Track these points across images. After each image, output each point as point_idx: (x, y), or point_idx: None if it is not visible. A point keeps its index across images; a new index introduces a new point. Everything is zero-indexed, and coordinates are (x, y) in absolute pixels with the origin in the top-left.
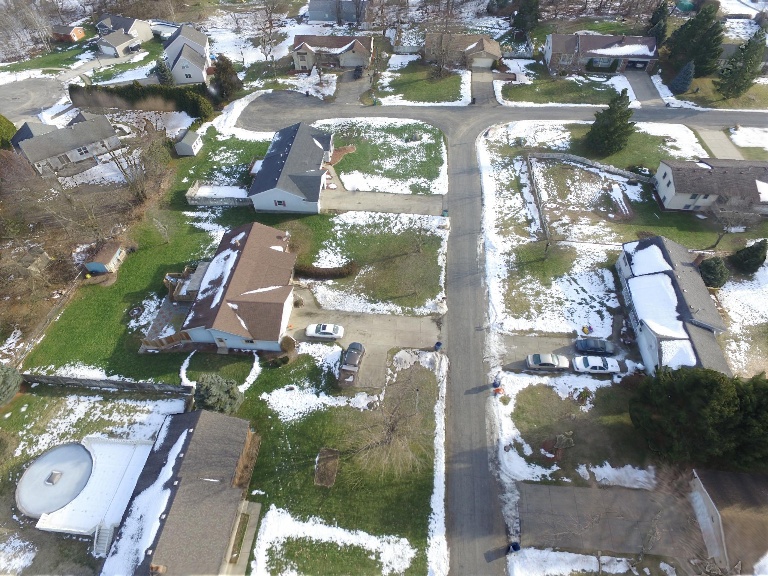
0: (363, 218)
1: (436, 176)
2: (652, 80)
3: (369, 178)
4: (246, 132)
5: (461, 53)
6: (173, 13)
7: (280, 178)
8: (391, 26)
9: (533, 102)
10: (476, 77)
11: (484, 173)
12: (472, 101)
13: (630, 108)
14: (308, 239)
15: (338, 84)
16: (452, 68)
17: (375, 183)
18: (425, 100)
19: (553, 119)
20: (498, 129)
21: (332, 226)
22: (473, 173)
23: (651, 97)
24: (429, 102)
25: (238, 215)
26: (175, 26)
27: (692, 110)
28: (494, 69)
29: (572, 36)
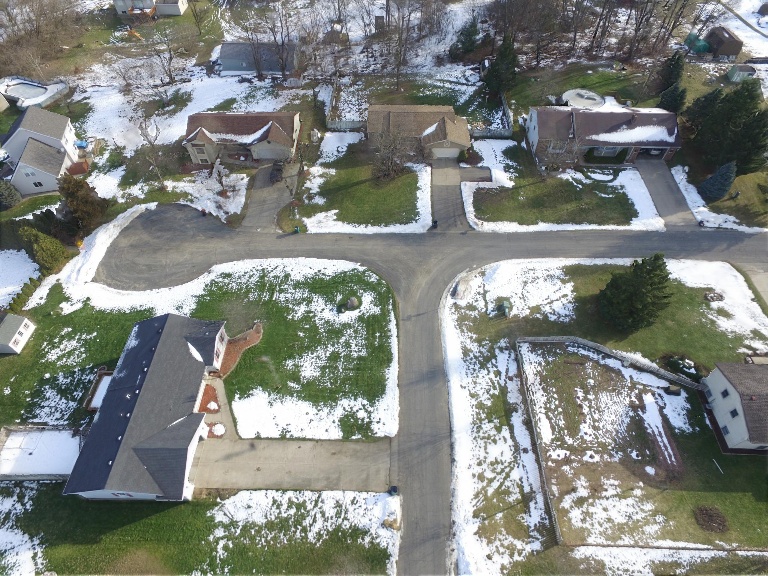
0: (262, 507)
1: (381, 392)
2: (673, 176)
3: (277, 405)
4: (107, 292)
5: (416, 139)
6: (38, 67)
7: (116, 461)
8: (327, 80)
9: (517, 222)
10: (438, 177)
11: (453, 381)
12: (433, 224)
13: (651, 231)
14: (167, 566)
15: (248, 192)
16: (405, 161)
17: (286, 417)
18: (368, 221)
19: (547, 257)
20: (471, 281)
21: (210, 529)
22: (436, 382)
23: (676, 208)
24: (373, 225)
25: (60, 505)
26: (41, 86)
27: (735, 232)
28: (462, 162)
29: (564, 114)
